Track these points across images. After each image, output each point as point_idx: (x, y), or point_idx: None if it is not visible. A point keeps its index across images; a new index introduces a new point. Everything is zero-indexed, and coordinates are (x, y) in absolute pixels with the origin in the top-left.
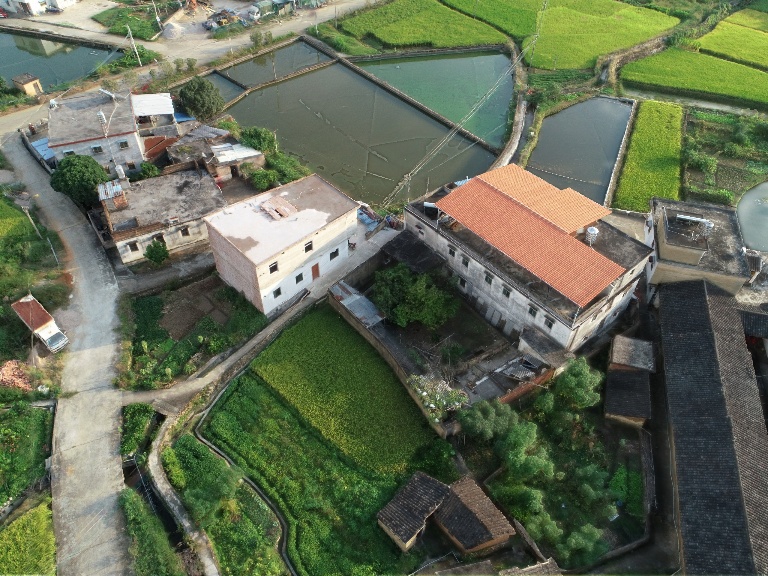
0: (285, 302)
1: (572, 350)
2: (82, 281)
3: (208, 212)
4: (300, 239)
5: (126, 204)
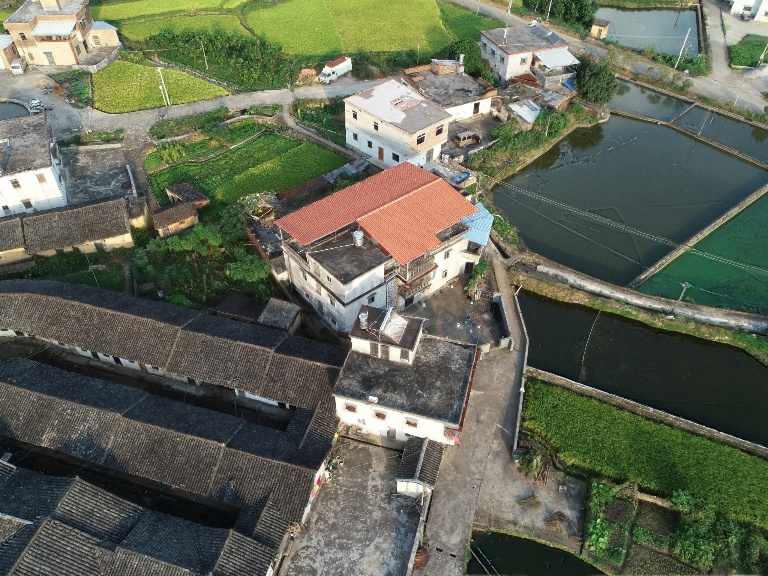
0: (359, 150)
1: (297, 287)
2: (380, 82)
3: (435, 102)
4: (370, 112)
5: (439, 73)
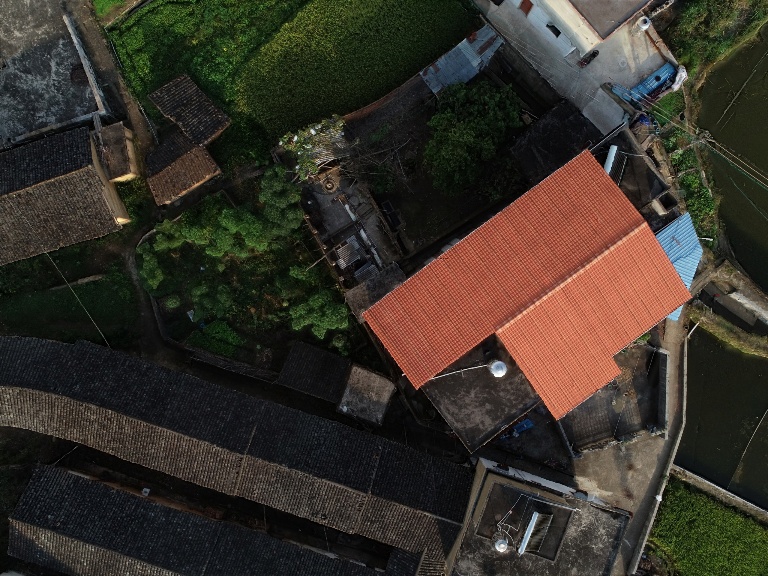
0: None
1: None
2: None
3: None
4: None
5: None
